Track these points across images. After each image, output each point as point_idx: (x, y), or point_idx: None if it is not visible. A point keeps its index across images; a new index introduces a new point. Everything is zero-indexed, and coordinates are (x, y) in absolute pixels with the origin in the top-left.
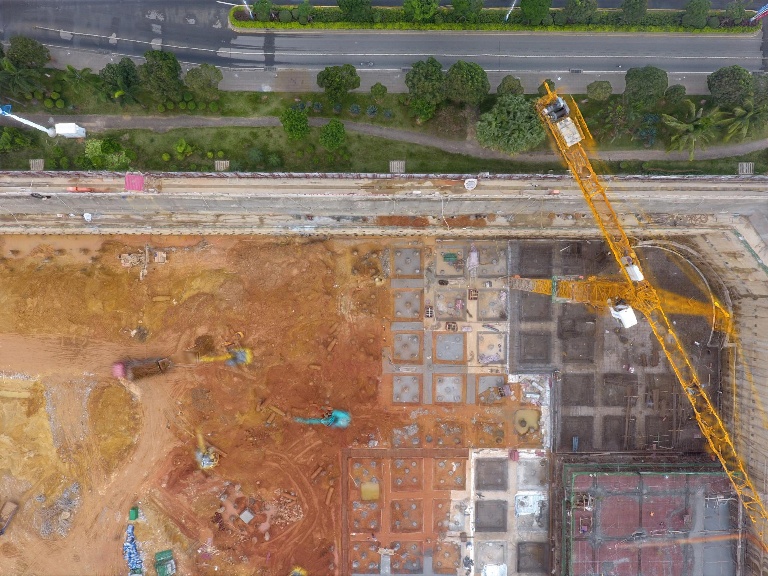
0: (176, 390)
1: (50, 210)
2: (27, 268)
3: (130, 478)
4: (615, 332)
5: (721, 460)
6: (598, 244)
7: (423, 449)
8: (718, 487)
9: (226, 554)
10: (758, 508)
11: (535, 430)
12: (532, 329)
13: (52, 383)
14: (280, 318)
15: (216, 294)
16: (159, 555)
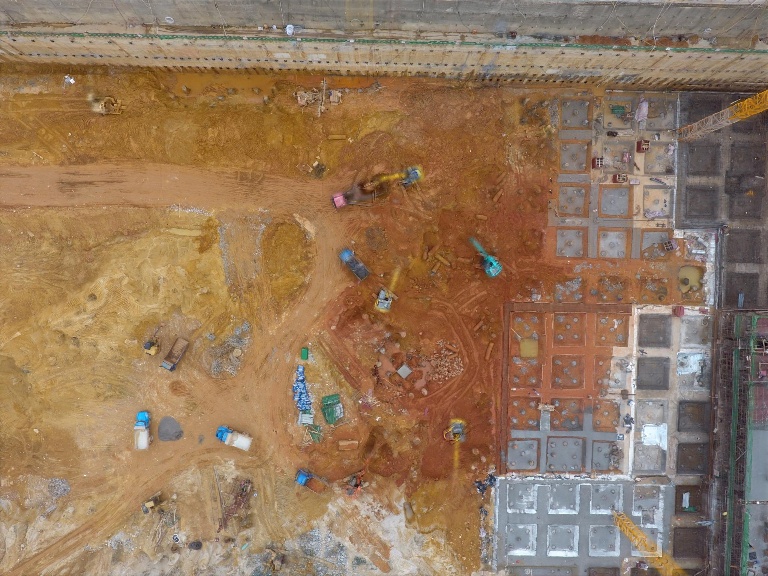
0: (350, 229)
1: (258, 16)
2: (200, 105)
3: (301, 318)
4: None
5: None
6: None
7: (586, 304)
8: None
9: (386, 406)
10: None
11: (697, 289)
12: (699, 183)
13: (227, 219)
14: (458, 157)
15: (393, 132)
16: (326, 399)
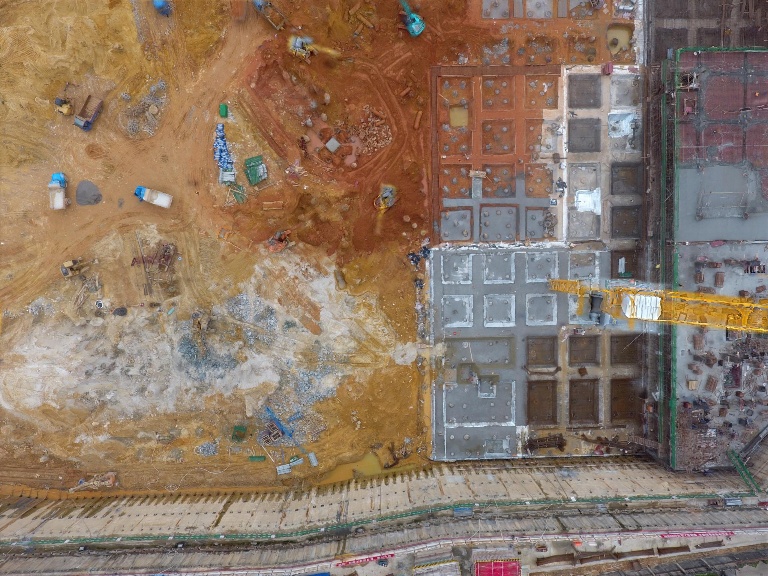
0: None
1: None
2: None
3: (218, 75)
4: None
5: None
6: None
7: (514, 66)
8: None
9: (314, 177)
10: None
11: (627, 50)
12: None
13: None
14: None
15: None
16: (249, 160)
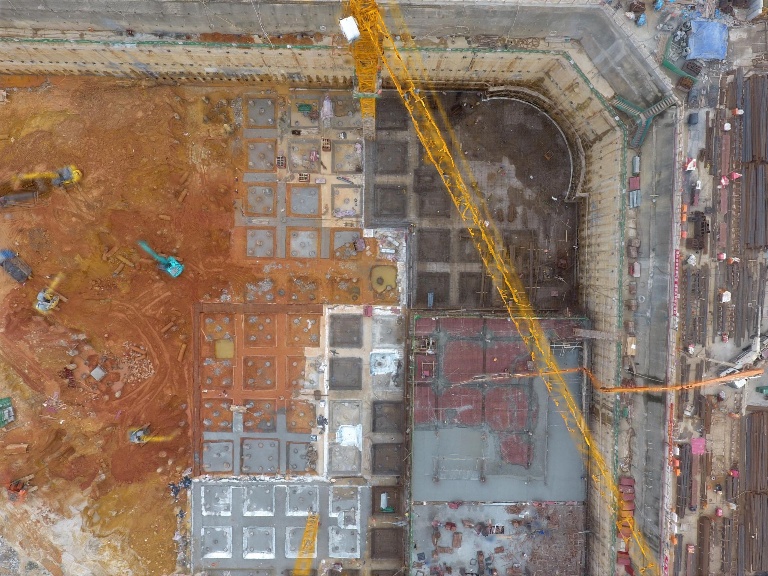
0: (13, 230)
1: None
2: None
3: None
4: (472, 186)
5: (439, 170)
6: (454, 95)
7: (276, 304)
8: (563, 333)
9: (73, 409)
10: (600, 351)
11: (392, 288)
12: (387, 182)
13: None
14: (120, 157)
15: (55, 132)
16: None
